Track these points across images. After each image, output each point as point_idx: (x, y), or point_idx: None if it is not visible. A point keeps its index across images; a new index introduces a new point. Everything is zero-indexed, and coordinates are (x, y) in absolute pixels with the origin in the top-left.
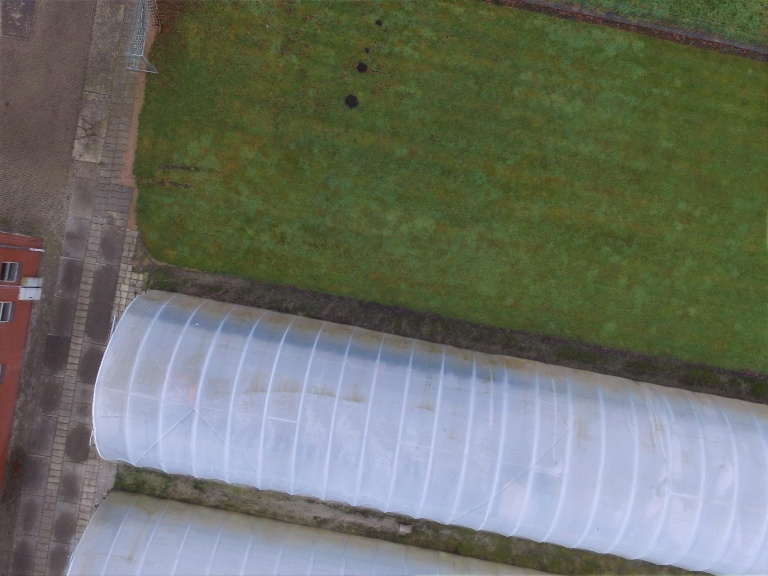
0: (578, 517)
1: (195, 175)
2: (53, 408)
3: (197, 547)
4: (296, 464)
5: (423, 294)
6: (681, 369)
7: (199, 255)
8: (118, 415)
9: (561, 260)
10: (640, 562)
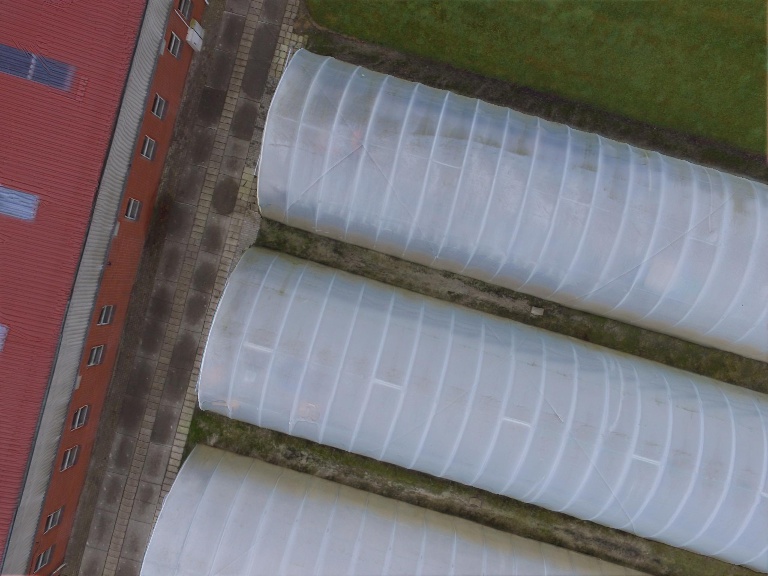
0: (726, 290)
1: None
2: (203, 159)
3: (343, 293)
4: (455, 211)
5: (575, 84)
6: None
7: (359, 24)
8: (287, 144)
9: (714, 63)
10: (764, 365)
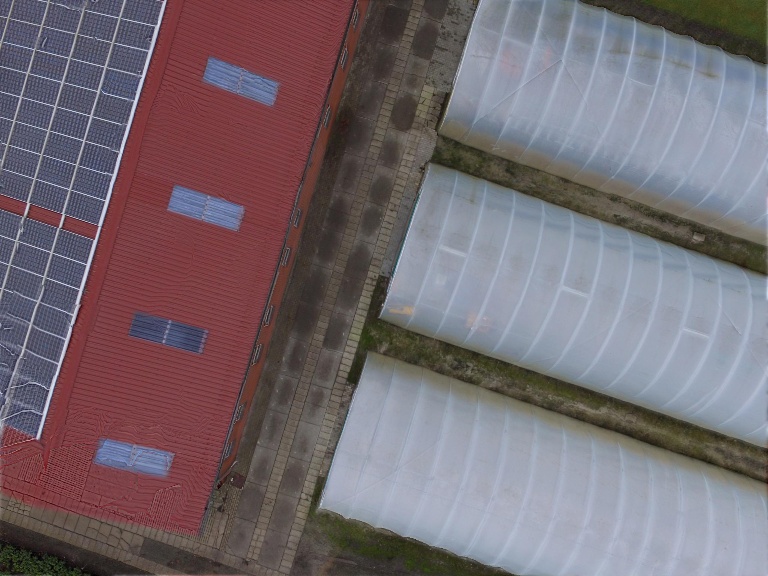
0: None
1: None
2: (384, 76)
3: (526, 206)
4: (644, 128)
5: (745, 18)
6: None
7: None
8: (488, 56)
9: None
10: None
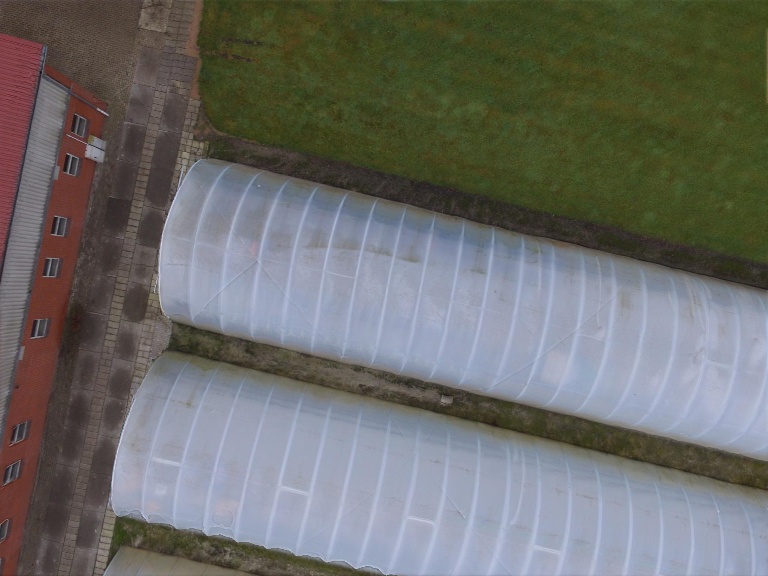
0: (617, 381)
1: (258, 49)
2: (112, 268)
3: (251, 399)
4: (352, 319)
5: (473, 176)
6: (717, 260)
7: (259, 127)
8: (183, 263)
9: (608, 149)
10: (668, 440)
